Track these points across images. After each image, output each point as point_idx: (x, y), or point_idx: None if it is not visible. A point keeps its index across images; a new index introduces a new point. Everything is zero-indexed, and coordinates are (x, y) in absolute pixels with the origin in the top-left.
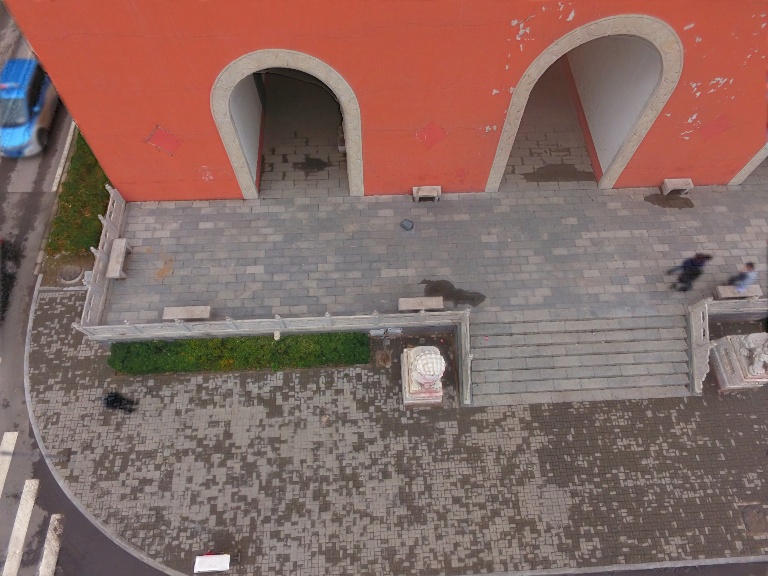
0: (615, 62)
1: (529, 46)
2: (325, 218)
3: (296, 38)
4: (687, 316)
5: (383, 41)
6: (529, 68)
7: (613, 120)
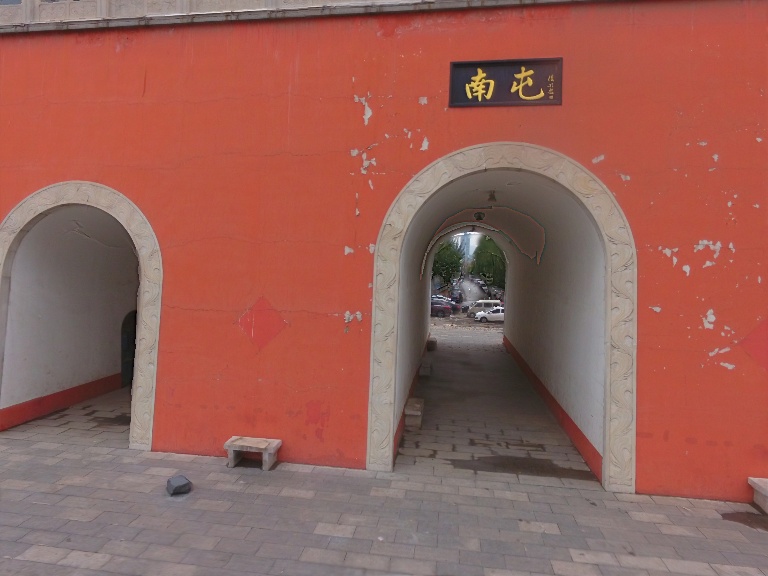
0: (567, 310)
1: (381, 184)
2: (50, 465)
3: (105, 170)
4: None
5: (200, 175)
6: (388, 214)
7: (586, 367)
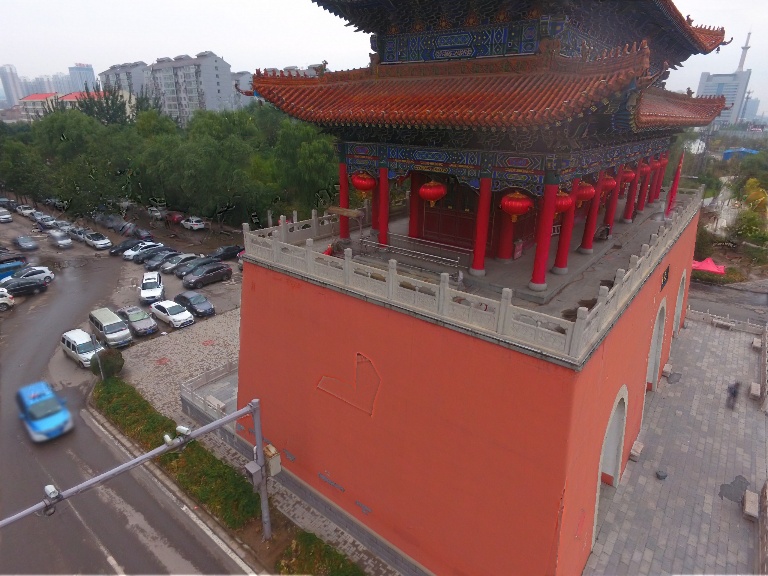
0: None
1: None
2: (635, 514)
3: None
4: (767, 414)
5: None
6: (651, 340)
7: None
